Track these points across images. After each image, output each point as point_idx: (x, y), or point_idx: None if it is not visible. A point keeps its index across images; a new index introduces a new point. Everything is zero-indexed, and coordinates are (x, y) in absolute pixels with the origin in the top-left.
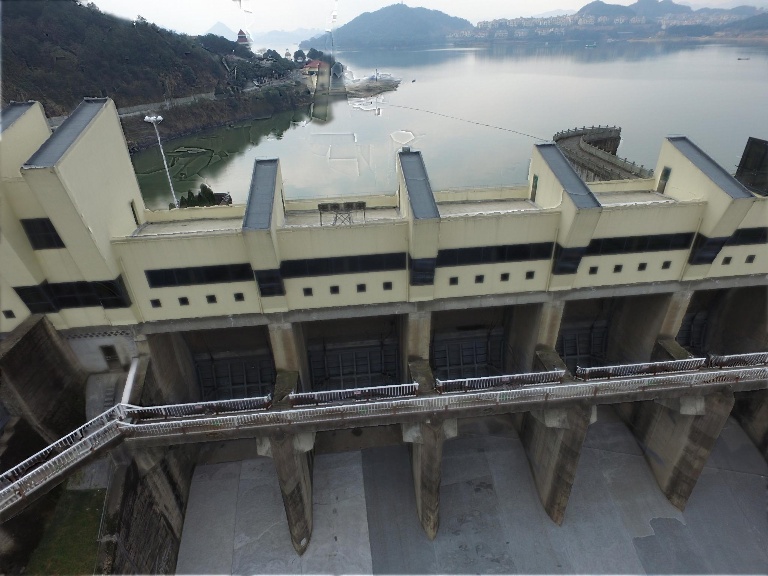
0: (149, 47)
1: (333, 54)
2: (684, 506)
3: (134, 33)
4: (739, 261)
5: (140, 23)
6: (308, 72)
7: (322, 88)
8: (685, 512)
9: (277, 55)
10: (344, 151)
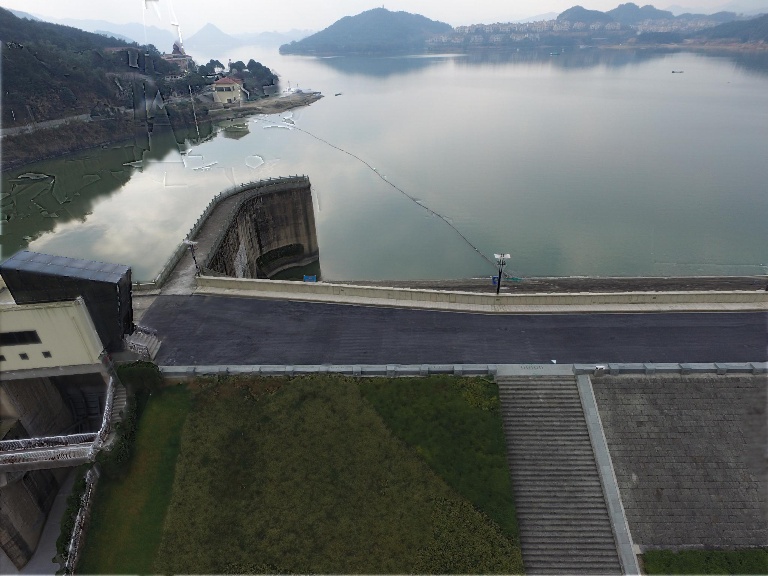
0: (19, 71)
1: (153, 87)
2: (16, 566)
3: (1, 58)
4: (15, 358)
5: (14, 47)
6: (215, 88)
7: (140, 120)
8: (23, 571)
9: (205, 68)
10: (178, 178)
